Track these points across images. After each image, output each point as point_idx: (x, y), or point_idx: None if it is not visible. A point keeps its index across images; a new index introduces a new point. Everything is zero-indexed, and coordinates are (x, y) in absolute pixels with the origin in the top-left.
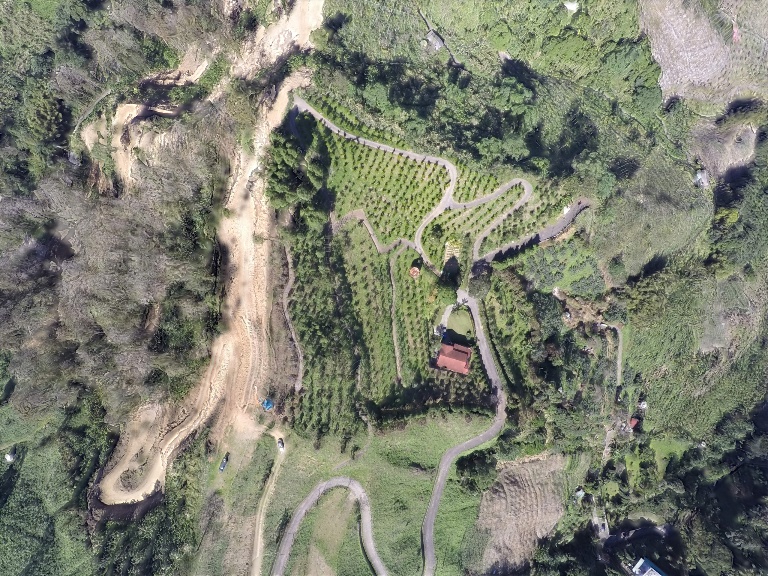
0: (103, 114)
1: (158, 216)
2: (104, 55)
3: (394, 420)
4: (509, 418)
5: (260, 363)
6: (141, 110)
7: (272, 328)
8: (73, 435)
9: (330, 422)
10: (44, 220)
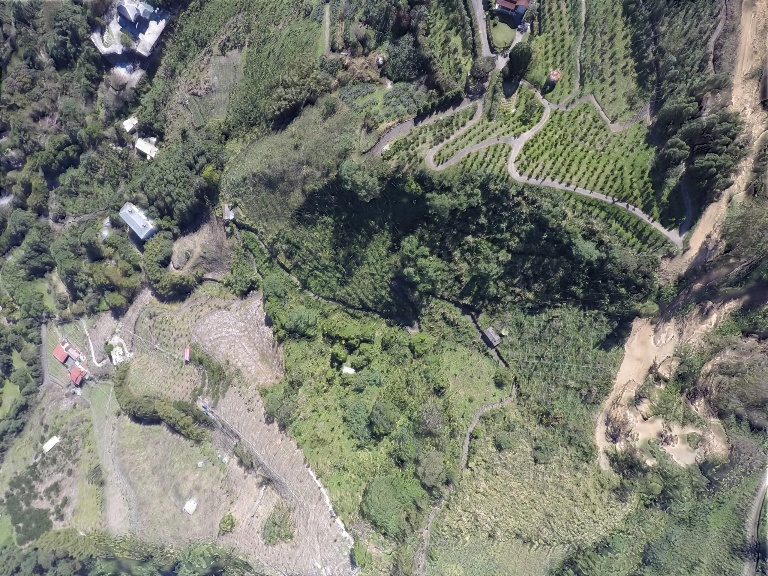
0: None
1: None
2: None
3: None
4: None
5: None
6: None
7: None
8: None
9: None
10: None
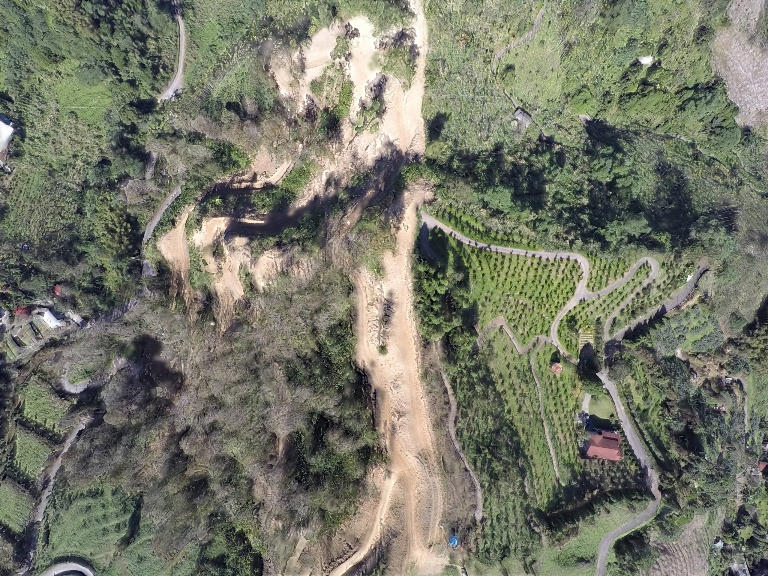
0: (177, 222)
1: (303, 356)
2: (178, 167)
3: (566, 526)
4: (667, 498)
5: (444, 502)
6: (230, 223)
7: (443, 460)
8: (214, 568)
9: (510, 544)
10: (131, 337)
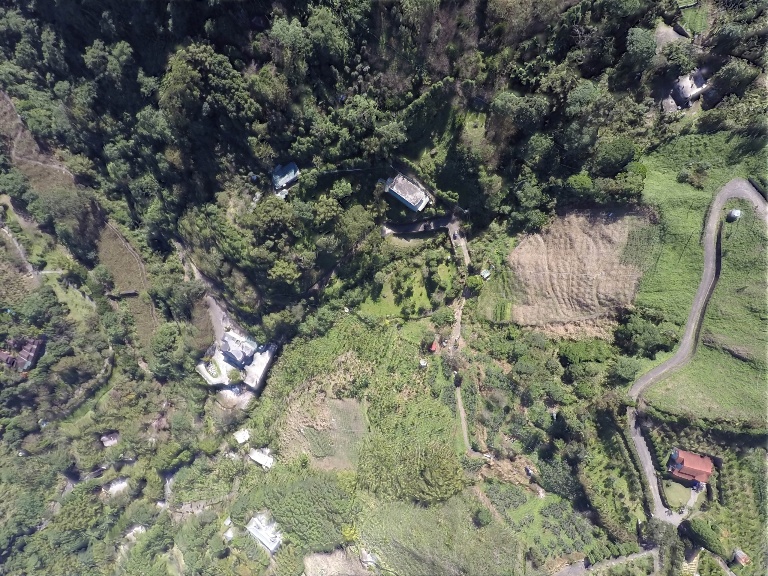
0: None
1: None
2: None
3: None
4: None
5: None
6: None
7: None
8: None
9: None
10: None
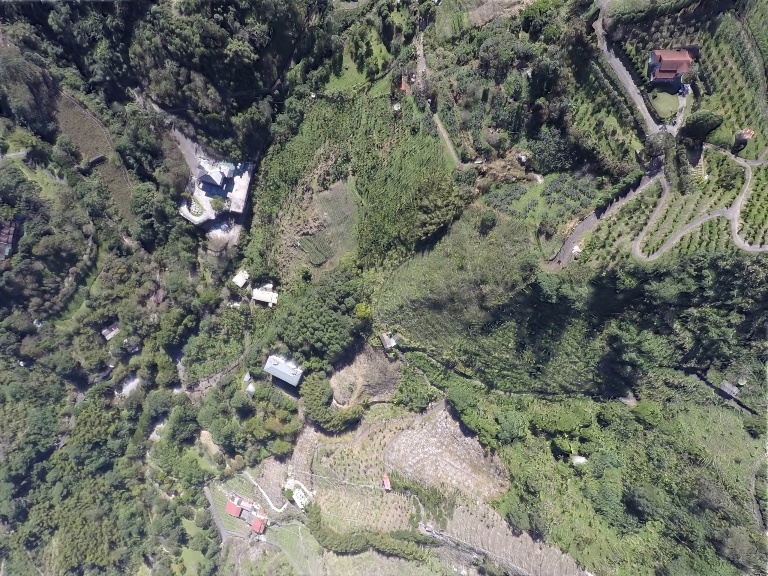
0: None
1: None
2: None
3: None
4: None
5: None
6: None
7: None
8: None
9: None
10: None
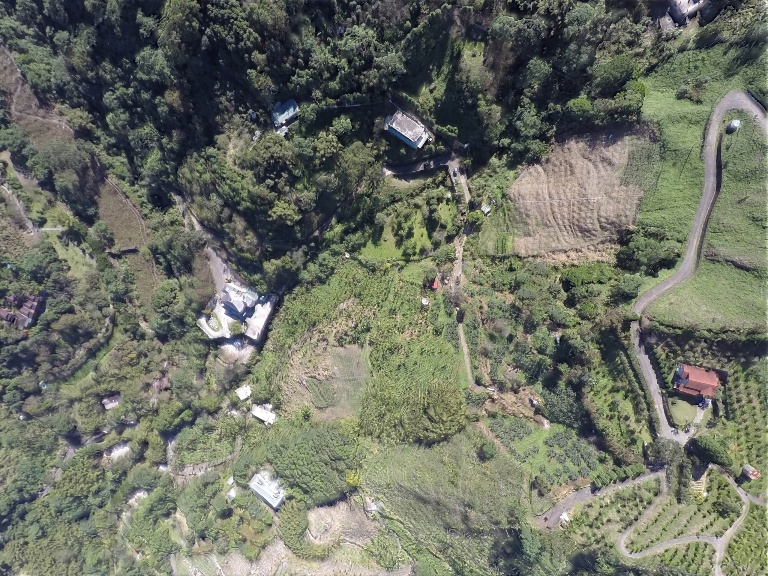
0: None
1: None
2: None
3: None
4: None
5: None
6: None
7: None
8: None
9: None
10: None
